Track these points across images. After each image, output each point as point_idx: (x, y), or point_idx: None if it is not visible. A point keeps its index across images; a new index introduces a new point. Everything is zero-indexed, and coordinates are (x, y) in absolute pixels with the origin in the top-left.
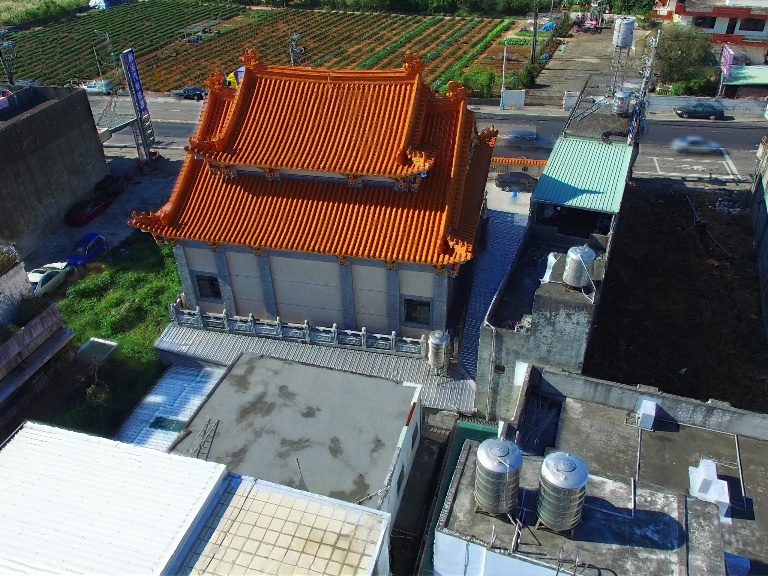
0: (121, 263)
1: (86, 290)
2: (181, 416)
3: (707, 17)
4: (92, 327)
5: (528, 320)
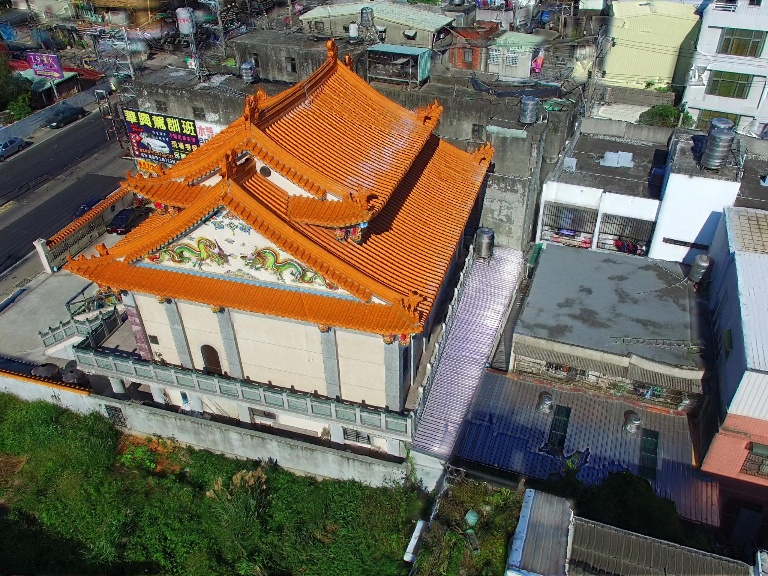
0: None
1: None
2: (546, 427)
3: None
4: None
5: None
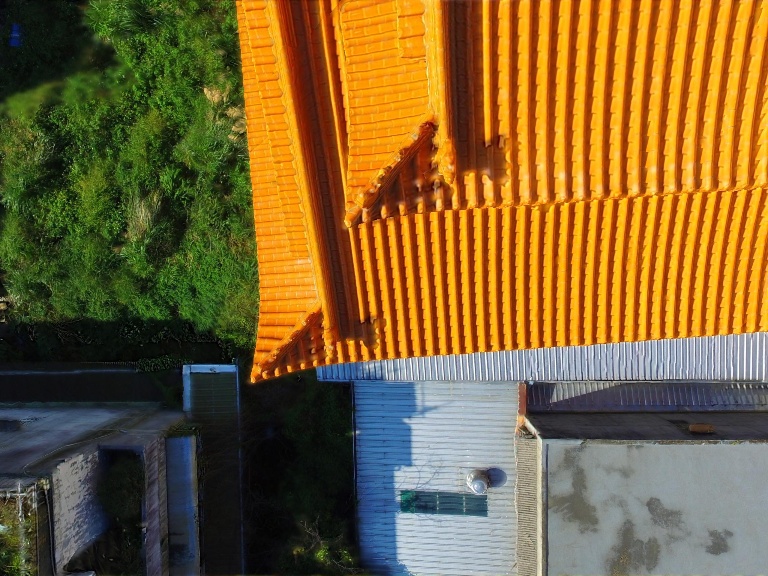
0: (30, 77)
1: (33, 187)
2: (439, 485)
3: None
4: (112, 266)
5: None
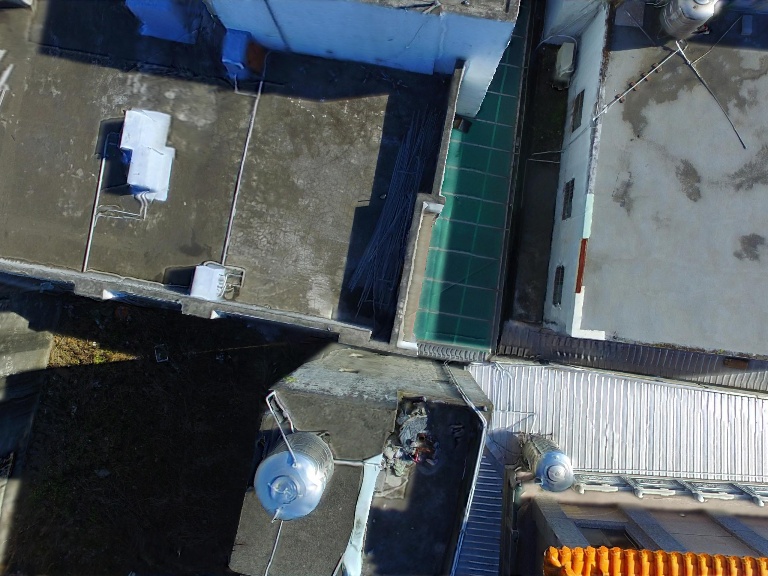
0: None
1: None
2: None
3: None
4: None
5: (396, 479)
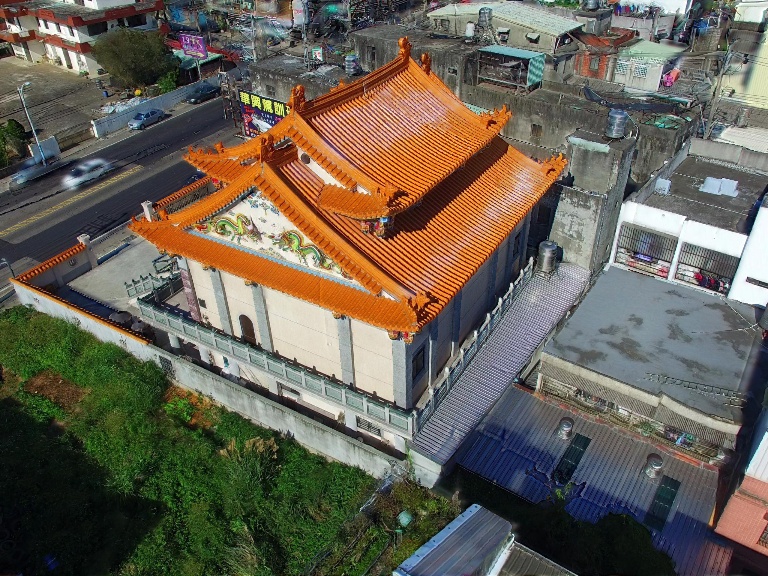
0: (86, 569)
1: None
2: (558, 454)
3: (100, 23)
4: None
5: None
